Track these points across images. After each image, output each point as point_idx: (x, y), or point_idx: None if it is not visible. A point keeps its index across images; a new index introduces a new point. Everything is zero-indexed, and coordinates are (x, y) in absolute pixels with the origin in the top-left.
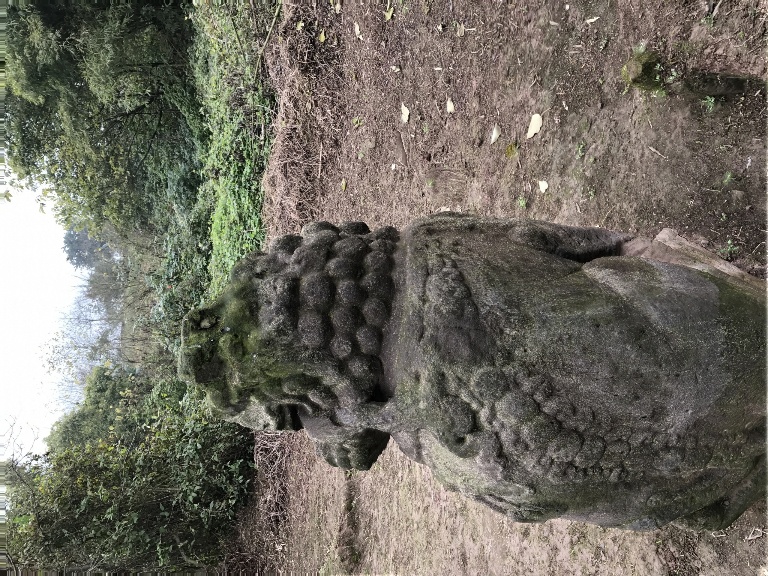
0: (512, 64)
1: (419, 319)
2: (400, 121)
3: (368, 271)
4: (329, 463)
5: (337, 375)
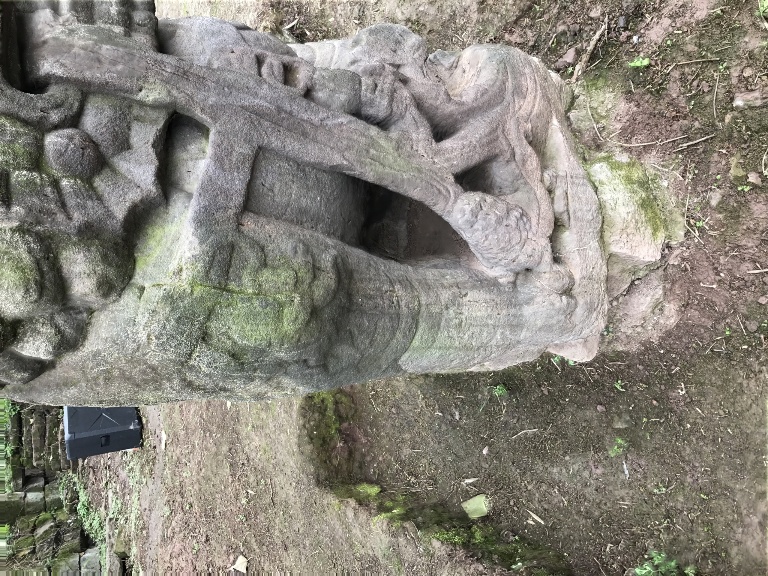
0: None
1: None
2: None
3: None
4: None
5: None
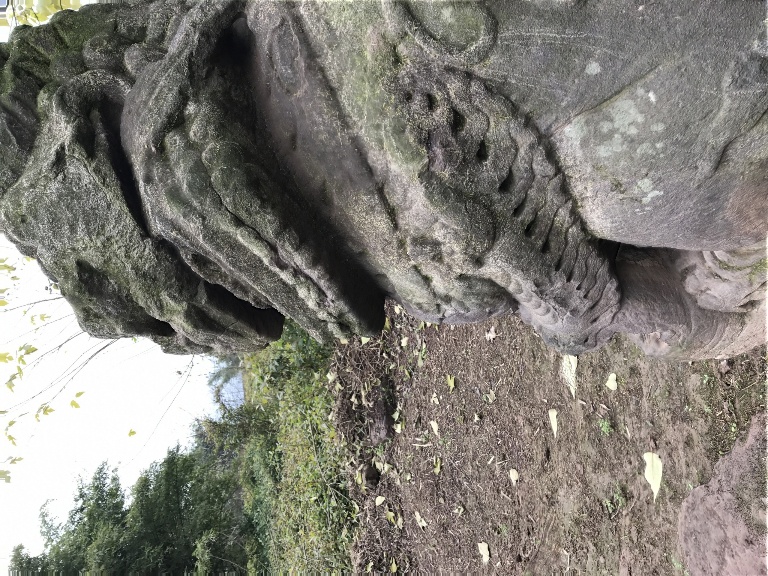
0: (533, 345)
1: None
2: (483, 567)
3: None
4: (174, 202)
5: (161, 5)
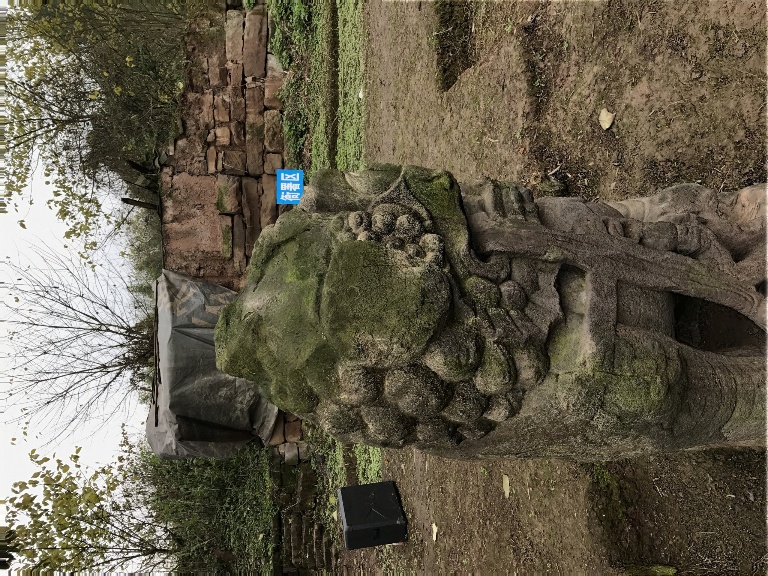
0: None
1: None
2: None
3: None
4: None
5: None
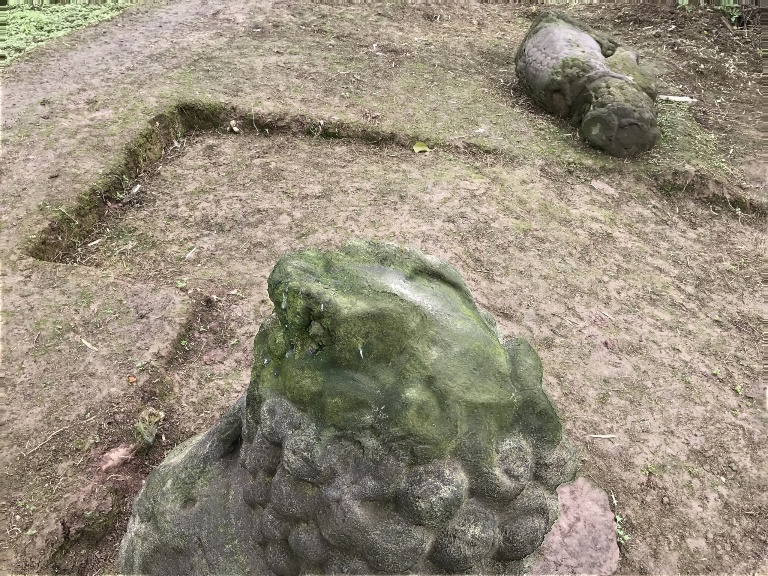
0: None
1: (209, 561)
2: None
3: (304, 562)
4: None
5: None
